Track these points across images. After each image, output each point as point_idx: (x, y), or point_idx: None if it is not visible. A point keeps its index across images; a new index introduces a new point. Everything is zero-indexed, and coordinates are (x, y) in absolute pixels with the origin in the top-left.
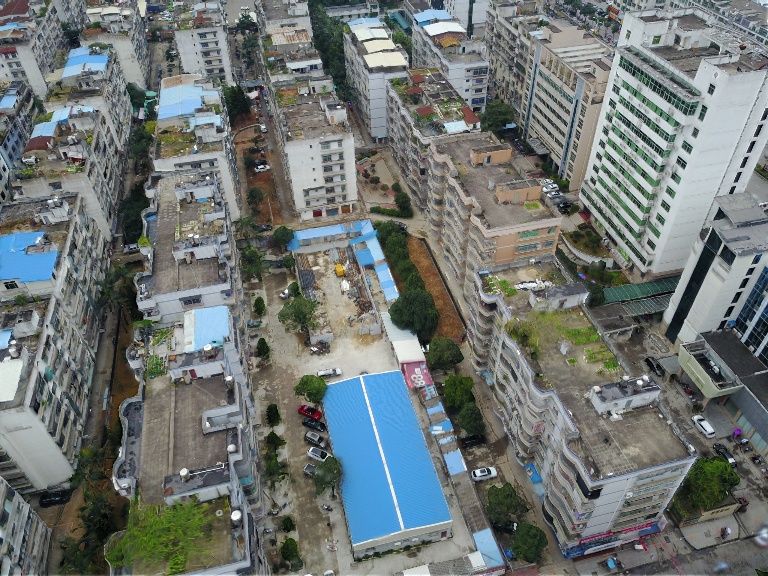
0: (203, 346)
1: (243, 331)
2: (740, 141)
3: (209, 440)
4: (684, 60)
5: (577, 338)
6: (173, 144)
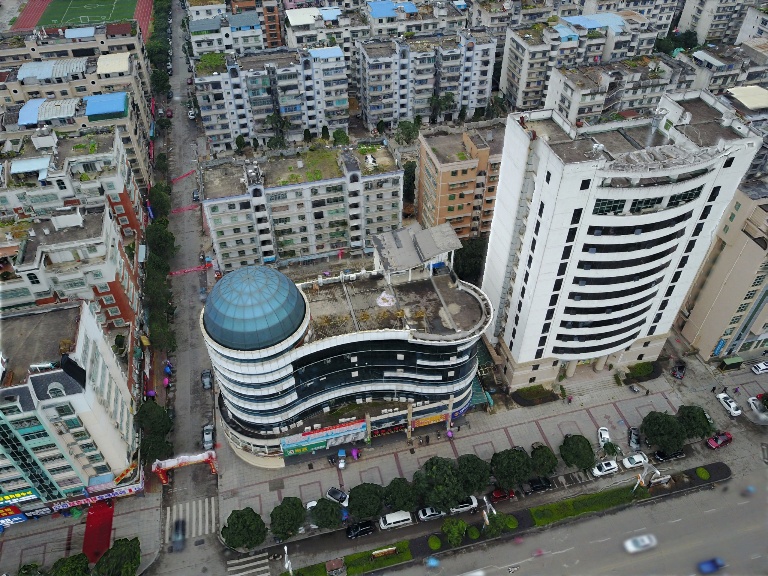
0: (312, 52)
1: (373, 101)
2: (527, 225)
3: (260, 68)
4: (628, 145)
5: (312, 173)
6: (536, 32)
